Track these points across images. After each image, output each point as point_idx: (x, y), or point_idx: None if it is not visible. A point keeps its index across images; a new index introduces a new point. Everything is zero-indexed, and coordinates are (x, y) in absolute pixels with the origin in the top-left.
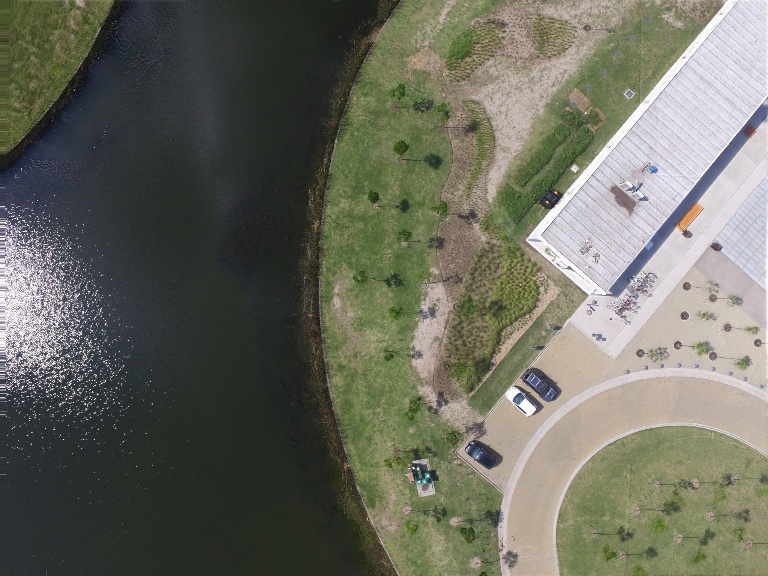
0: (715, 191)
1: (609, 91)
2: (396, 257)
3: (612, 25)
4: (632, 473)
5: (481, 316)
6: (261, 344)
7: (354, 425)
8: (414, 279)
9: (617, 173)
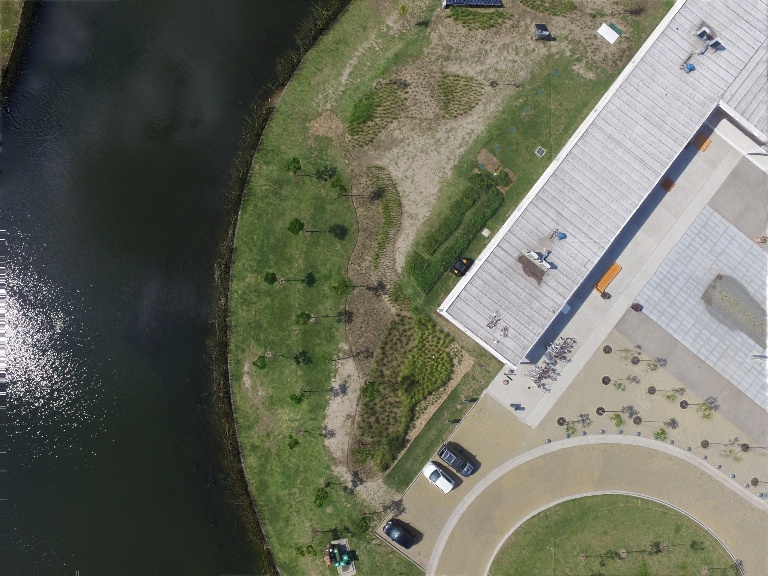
0: (634, 249)
1: (519, 150)
2: (304, 334)
3: (520, 79)
4: (556, 546)
5: (394, 391)
6: (173, 426)
7: (270, 506)
8: None
9: (524, 241)
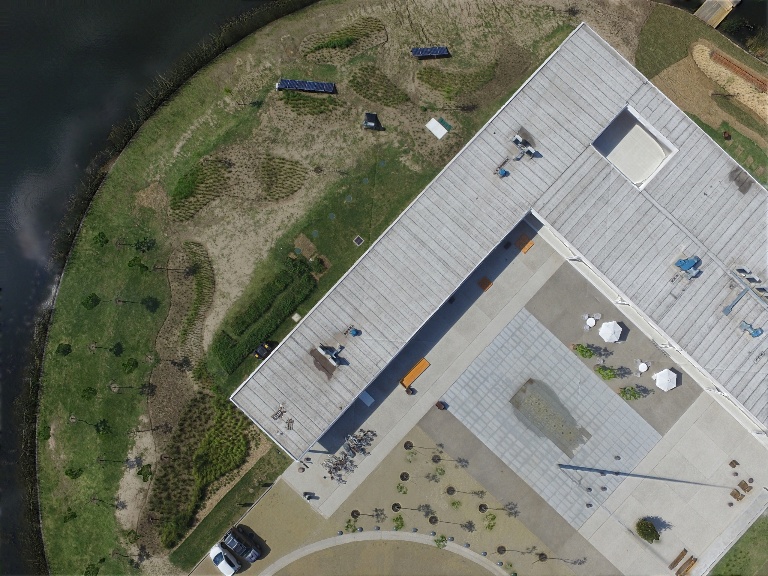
0: (444, 346)
1: (337, 237)
2: (106, 403)
3: (345, 167)
4: None
5: (188, 469)
6: None
7: (63, 570)
8: (123, 426)
9: (317, 335)
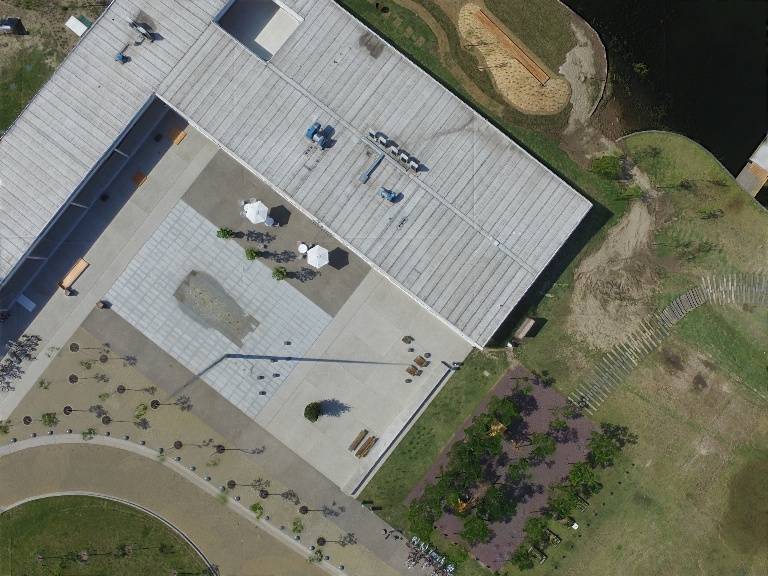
0: (102, 245)
1: None
2: None
3: None
4: (12, 547)
5: None
6: None
7: None
8: None
9: None
